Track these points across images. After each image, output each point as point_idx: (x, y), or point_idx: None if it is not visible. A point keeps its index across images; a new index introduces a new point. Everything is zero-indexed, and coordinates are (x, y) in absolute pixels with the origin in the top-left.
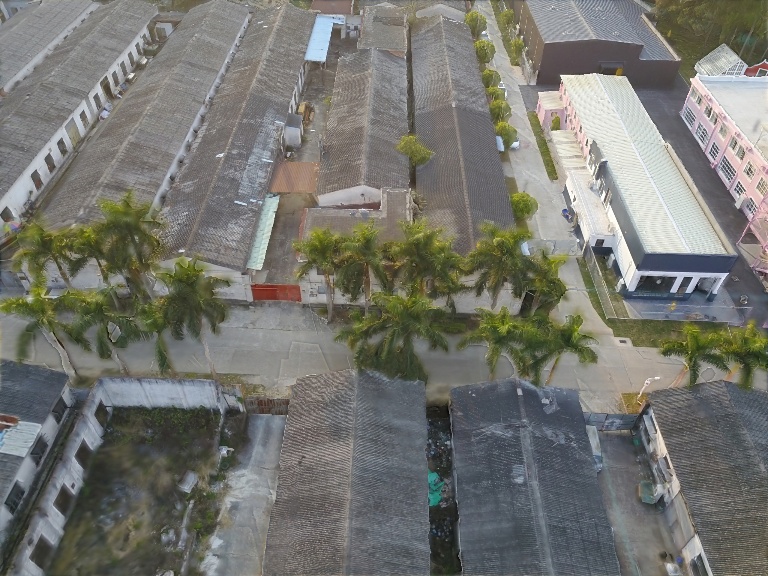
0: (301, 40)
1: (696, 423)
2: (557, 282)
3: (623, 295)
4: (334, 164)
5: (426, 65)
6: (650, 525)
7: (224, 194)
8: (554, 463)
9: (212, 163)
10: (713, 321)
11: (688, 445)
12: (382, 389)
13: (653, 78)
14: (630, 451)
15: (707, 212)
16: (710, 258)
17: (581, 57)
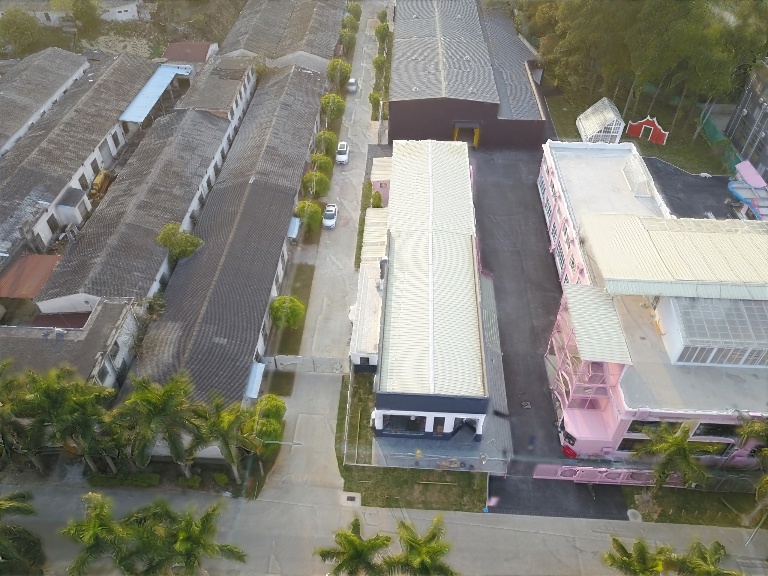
0: (125, 96)
1: None
2: (241, 439)
3: (375, 431)
4: (73, 260)
5: (252, 126)
6: None
7: None
8: None
9: None
10: (470, 471)
11: None
12: None
13: (517, 138)
14: None
15: (480, 331)
16: (456, 400)
17: (432, 116)
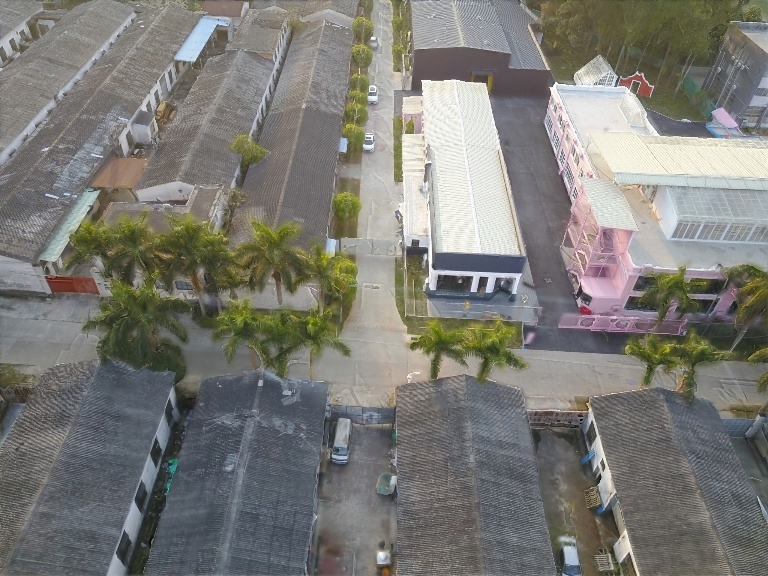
0: (176, 40)
1: (430, 416)
2: (334, 278)
3: (428, 294)
4: (162, 160)
5: (295, 68)
6: (381, 516)
7: (36, 187)
8: (272, 452)
9: (35, 157)
10: (508, 320)
11: (416, 437)
12: (124, 378)
13: (524, 86)
14: (385, 444)
15: (514, 214)
16: (499, 258)
17: (452, 64)
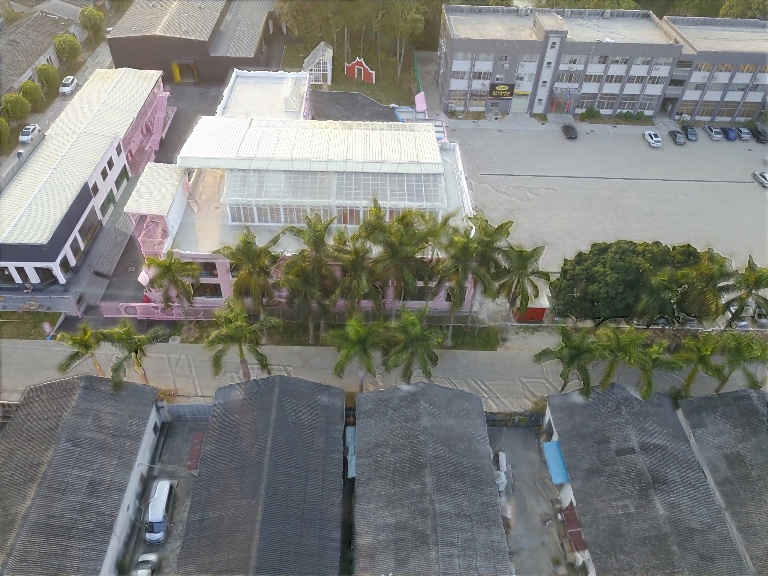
0: None
1: None
2: None
3: None
4: None
5: None
6: None
7: None
8: None
9: None
10: (46, 311)
11: None
12: None
13: None
14: None
15: None
16: (20, 247)
17: (151, 53)
